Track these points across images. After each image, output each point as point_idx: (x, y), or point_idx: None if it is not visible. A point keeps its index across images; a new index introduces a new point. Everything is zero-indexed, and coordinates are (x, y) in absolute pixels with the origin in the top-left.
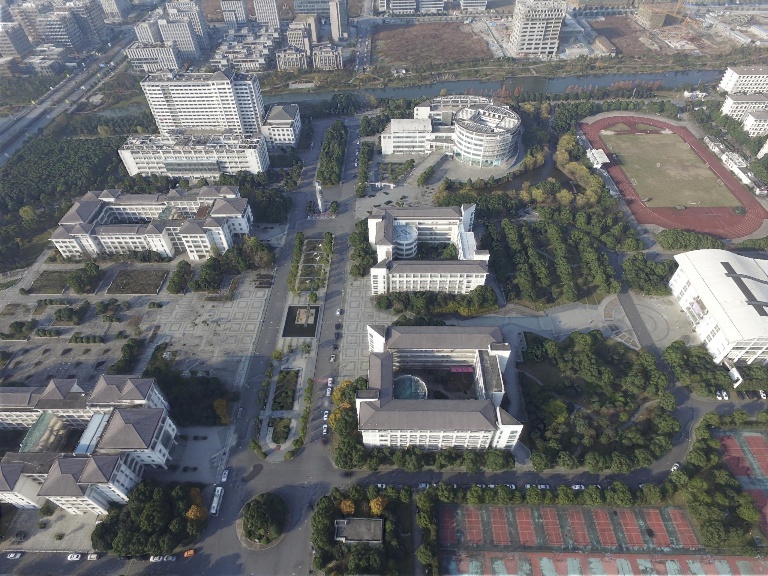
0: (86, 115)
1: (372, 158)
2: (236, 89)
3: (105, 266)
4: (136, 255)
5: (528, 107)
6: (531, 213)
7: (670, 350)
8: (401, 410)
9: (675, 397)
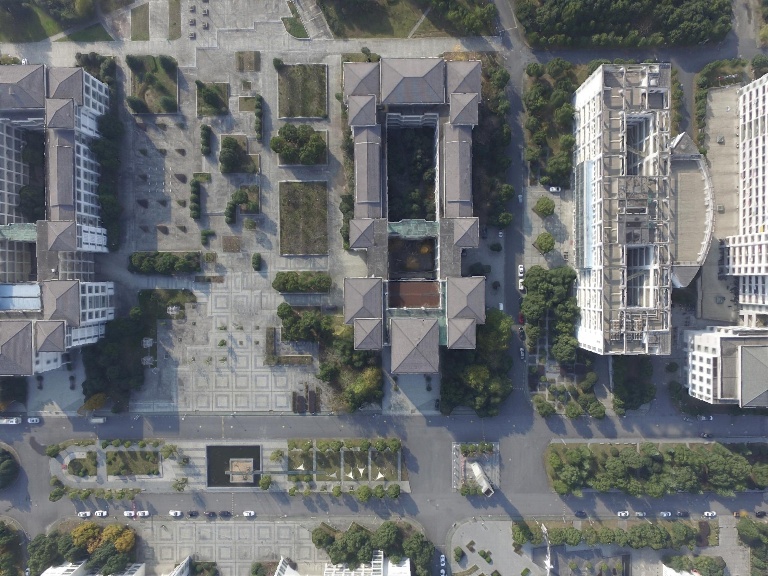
0: None
1: None
2: None
3: (337, 154)
4: (346, 200)
5: None
6: None
7: None
8: None
9: None
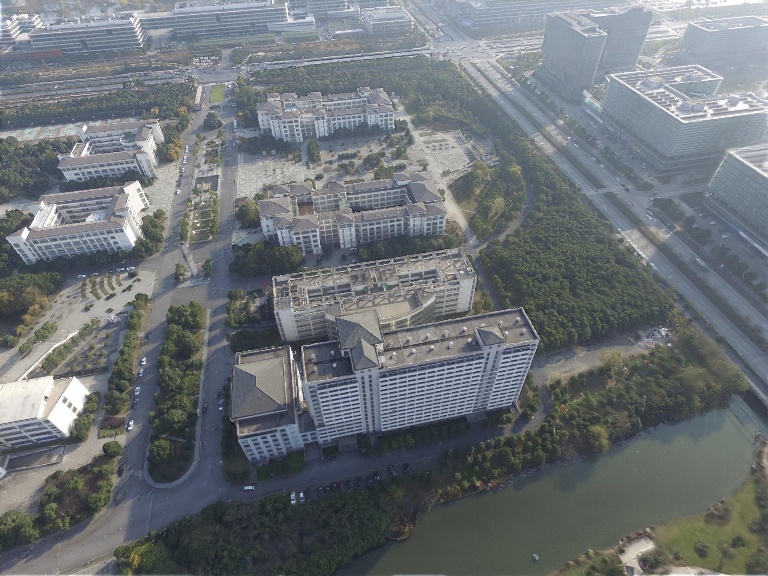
0: (697, 386)
1: None
2: None
3: None
4: None
5: None
6: None
7: None
8: (134, 122)
9: None
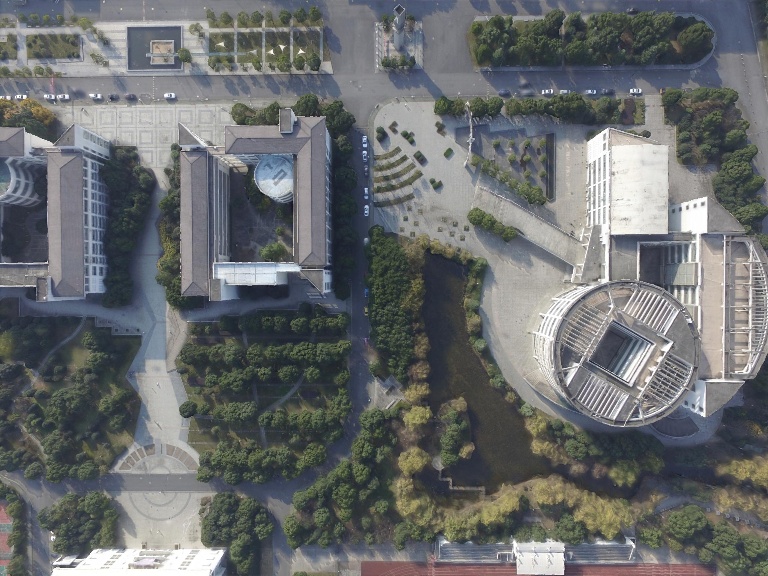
0: None
1: (572, 122)
2: None
3: None
4: None
5: (760, 470)
6: (390, 397)
7: (92, 501)
8: None
9: (27, 479)
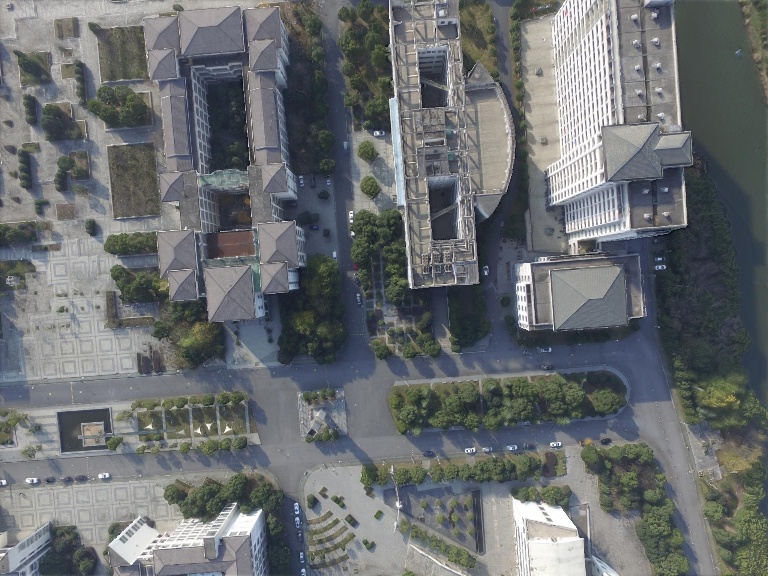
0: None
1: None
2: (614, 190)
3: None
4: None
5: None
6: None
7: None
8: None
9: None
